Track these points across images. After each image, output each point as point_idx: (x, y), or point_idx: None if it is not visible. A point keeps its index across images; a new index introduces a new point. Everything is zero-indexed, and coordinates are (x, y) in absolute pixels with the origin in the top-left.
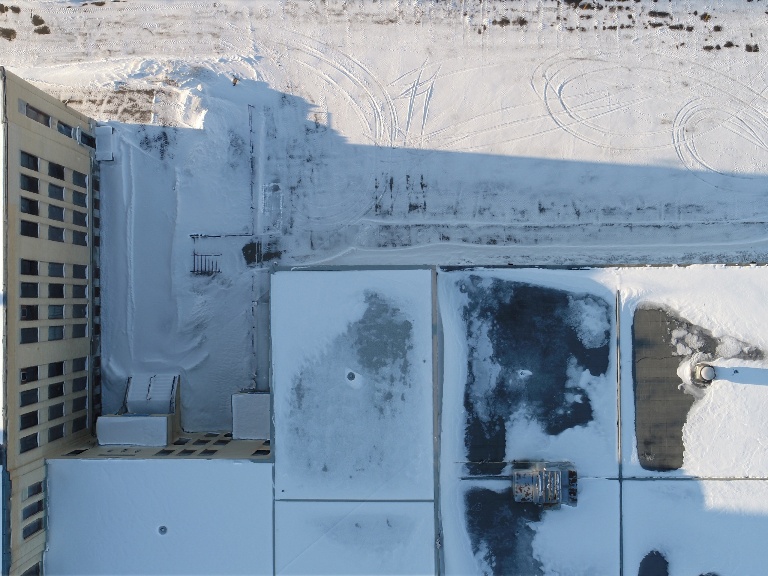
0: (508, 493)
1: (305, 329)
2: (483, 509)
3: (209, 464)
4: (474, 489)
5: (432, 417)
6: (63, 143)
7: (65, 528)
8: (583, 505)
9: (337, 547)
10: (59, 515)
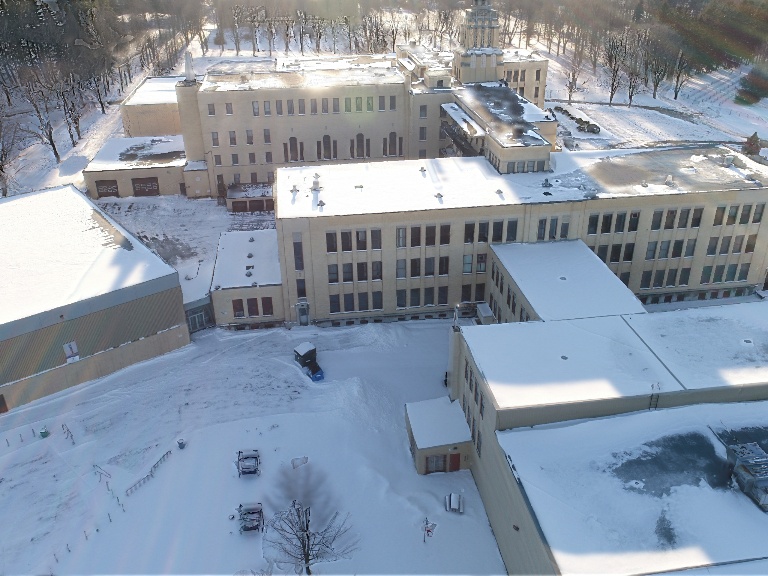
0: (722, 461)
1: (762, 318)
2: (692, 445)
3: (625, 288)
4: (706, 437)
5: (759, 382)
6: (767, 250)
7: (541, 248)
8: (759, 520)
9: (606, 346)
10: (548, 246)
